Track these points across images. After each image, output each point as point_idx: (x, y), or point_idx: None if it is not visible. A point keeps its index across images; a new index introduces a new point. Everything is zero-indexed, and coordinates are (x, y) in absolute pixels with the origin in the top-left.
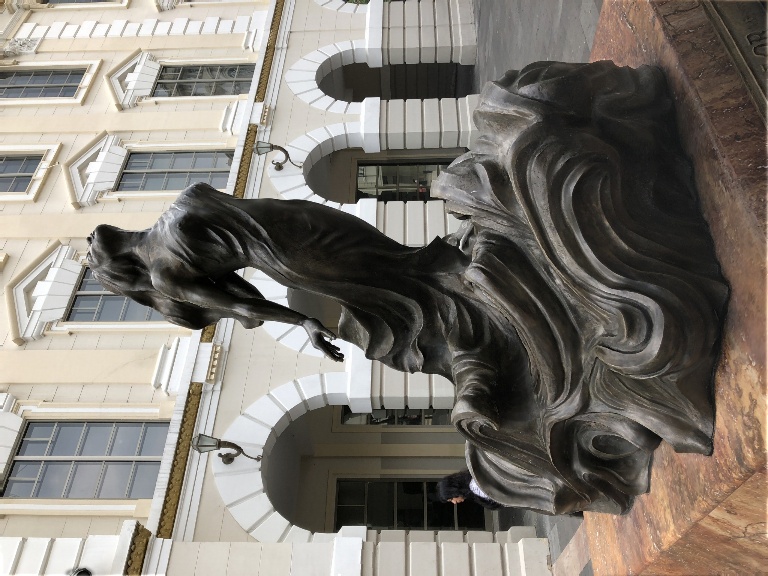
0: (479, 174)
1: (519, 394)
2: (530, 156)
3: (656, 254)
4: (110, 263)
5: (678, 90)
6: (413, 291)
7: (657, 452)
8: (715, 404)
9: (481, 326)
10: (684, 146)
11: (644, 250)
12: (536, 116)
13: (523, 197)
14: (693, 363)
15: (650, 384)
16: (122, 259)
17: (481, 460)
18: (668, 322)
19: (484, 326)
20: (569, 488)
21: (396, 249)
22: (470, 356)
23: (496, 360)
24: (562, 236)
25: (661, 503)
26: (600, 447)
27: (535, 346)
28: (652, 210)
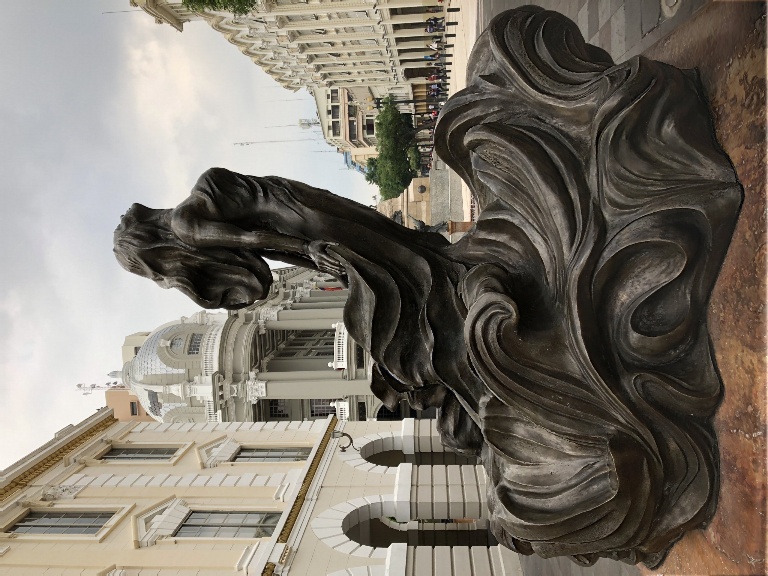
0: None
1: (539, 311)
2: (505, 26)
3: None
4: (136, 224)
5: None
6: (421, 252)
7: (712, 326)
8: (726, 153)
9: None
10: None
11: None
12: None
13: (504, 52)
14: (681, 95)
15: (655, 158)
16: (148, 223)
17: (515, 498)
18: None
19: None
20: (626, 434)
21: None
22: None
23: None
24: (541, 69)
25: (736, 366)
26: (642, 332)
27: (536, 174)
28: None
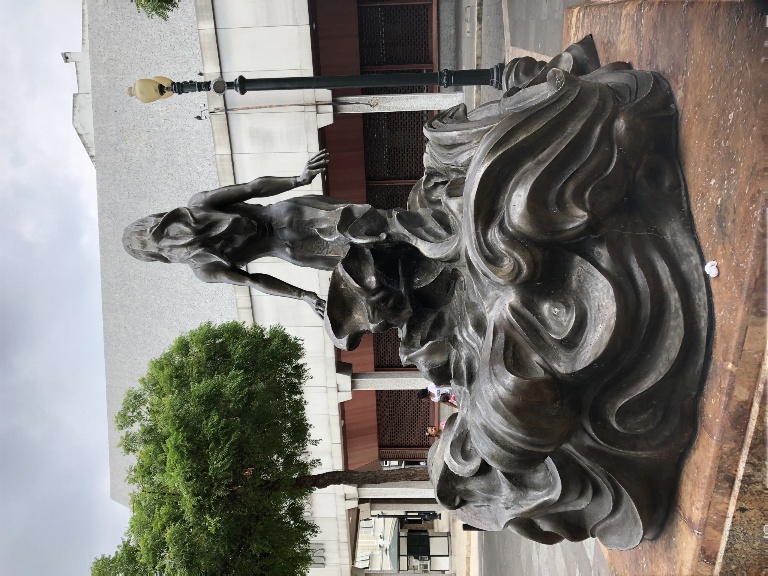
0: None
1: None
2: None
3: None
4: None
5: None
6: None
7: None
8: None
9: None
10: None
11: None
12: None
13: None
14: None
15: None
16: None
17: None
18: None
19: None
20: None
21: None
22: None
23: None
24: None
25: (623, 41)
26: None
27: None
28: None
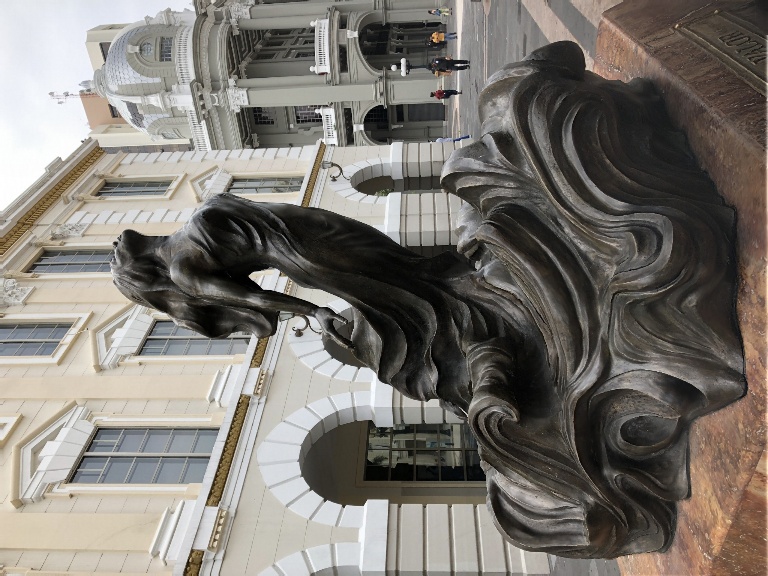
0: (485, 142)
1: (538, 390)
2: (530, 101)
3: (659, 188)
4: (132, 263)
5: (664, 84)
6: (426, 293)
7: (692, 441)
8: (741, 335)
9: (495, 326)
10: (675, 124)
11: (646, 184)
12: (533, 70)
13: (526, 140)
14: (709, 277)
15: (670, 321)
16: (144, 260)
17: (503, 504)
18: (677, 228)
19: (498, 326)
20: (602, 506)
21: (409, 255)
22: (485, 344)
23: (512, 351)
24: (566, 175)
25: (705, 496)
26: (630, 439)
27: (549, 299)
28: (650, 158)
